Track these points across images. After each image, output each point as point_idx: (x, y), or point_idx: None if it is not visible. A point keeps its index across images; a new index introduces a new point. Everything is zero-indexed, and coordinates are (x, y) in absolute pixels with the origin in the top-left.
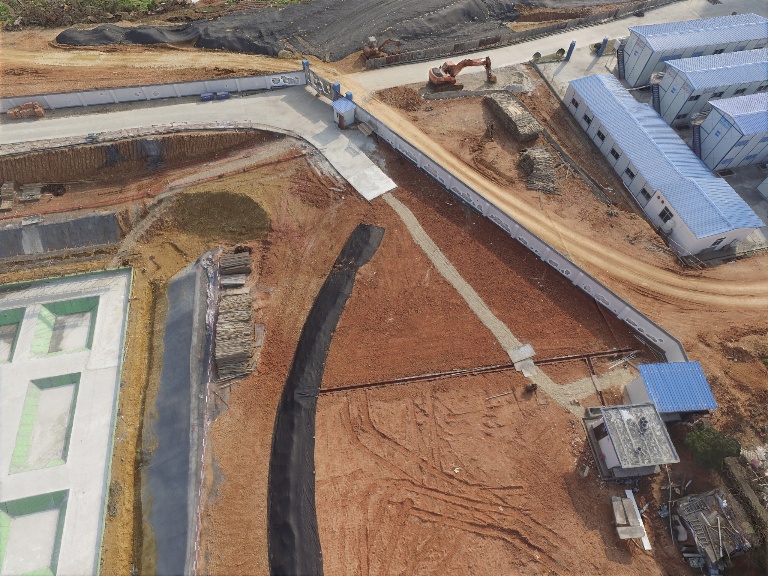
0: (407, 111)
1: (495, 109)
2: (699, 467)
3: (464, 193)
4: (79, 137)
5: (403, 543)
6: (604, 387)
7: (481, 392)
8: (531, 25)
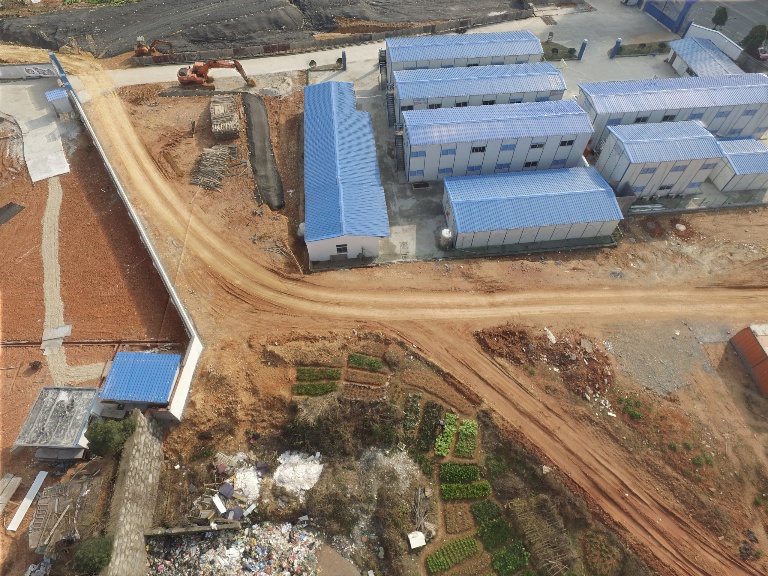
0: (133, 105)
1: None
2: None
3: None
4: None
5: None
6: None
7: None
8: (340, 36)
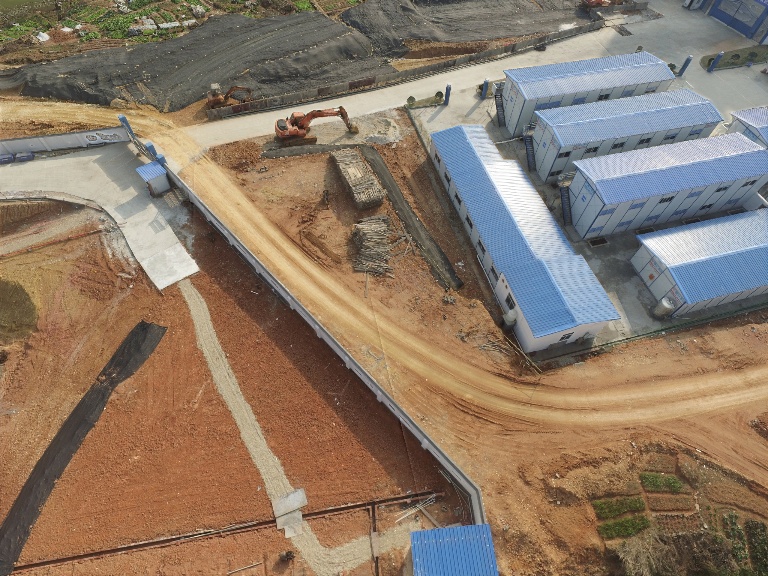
0: (238, 173)
1: (338, 169)
2: None
3: None
4: None
5: None
6: (383, 550)
7: (223, 563)
8: (418, 62)
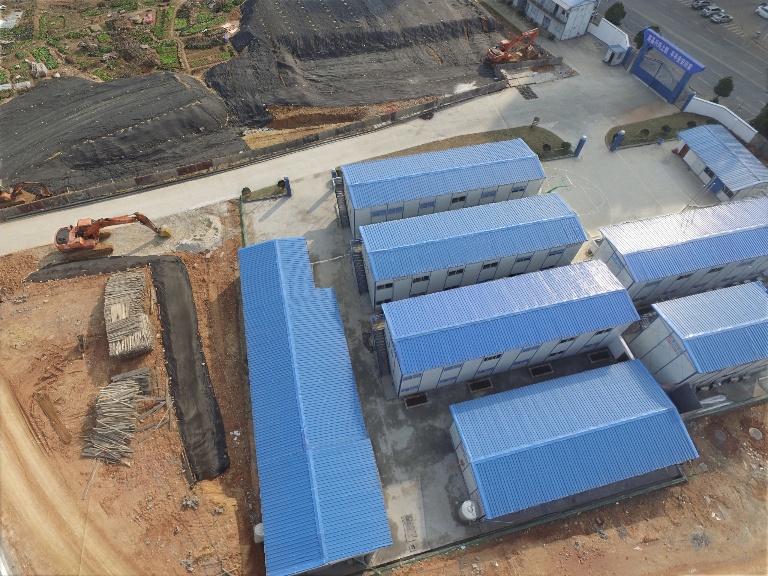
0: None
1: None
2: None
3: None
4: None
5: None
6: None
7: None
8: (277, 135)
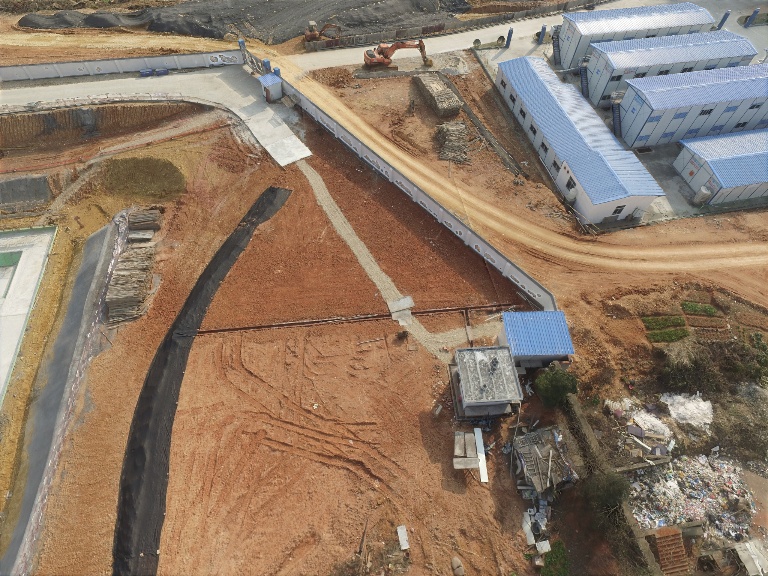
0: (336, 88)
1: (421, 87)
2: (546, 407)
3: (374, 161)
4: (20, 106)
5: (249, 469)
6: (476, 337)
7: (354, 338)
8: (480, 16)
